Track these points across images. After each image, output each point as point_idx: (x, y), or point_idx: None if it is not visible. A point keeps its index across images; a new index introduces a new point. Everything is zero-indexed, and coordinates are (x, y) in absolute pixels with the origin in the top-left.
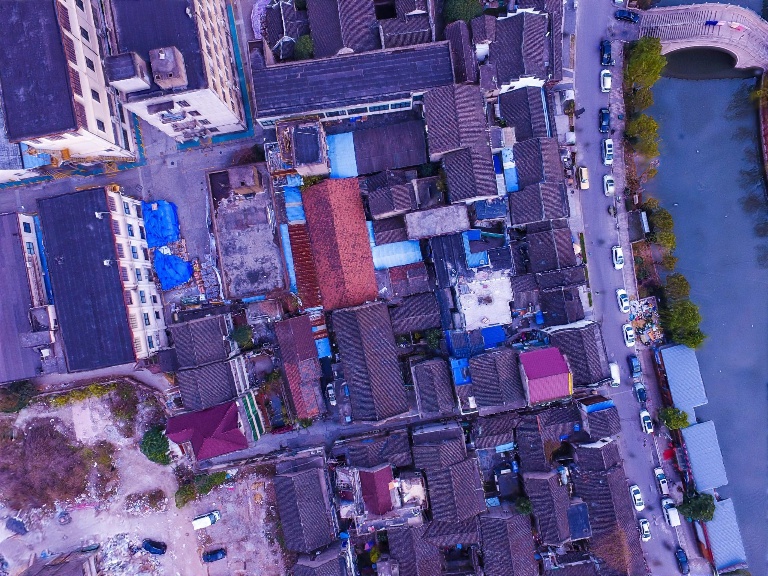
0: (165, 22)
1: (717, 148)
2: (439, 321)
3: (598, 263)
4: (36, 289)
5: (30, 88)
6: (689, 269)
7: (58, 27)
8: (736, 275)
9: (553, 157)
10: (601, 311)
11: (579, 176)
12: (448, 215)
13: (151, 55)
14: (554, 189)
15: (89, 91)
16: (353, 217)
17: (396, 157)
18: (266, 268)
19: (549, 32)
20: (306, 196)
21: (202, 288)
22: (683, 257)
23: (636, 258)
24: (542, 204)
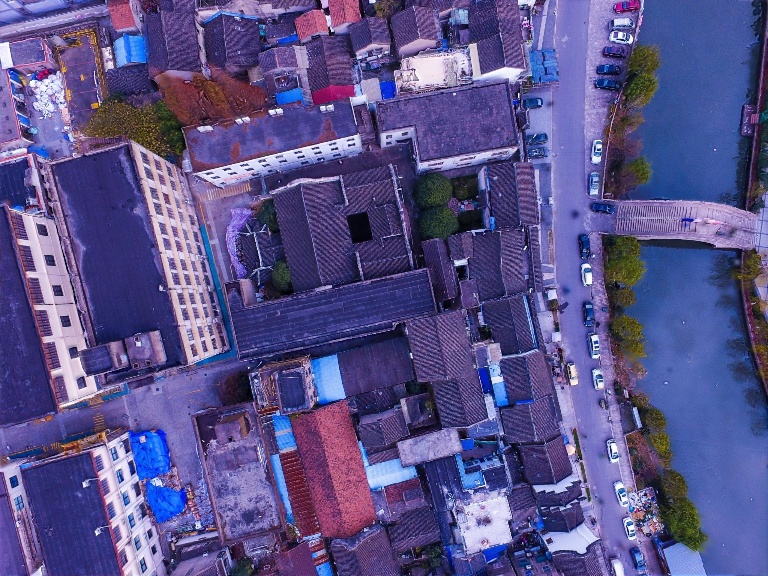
0: (139, 297)
1: (702, 317)
2: (439, 536)
3: (593, 457)
4: (28, 547)
5: (6, 375)
6: (684, 440)
7: (30, 309)
8: (731, 444)
9: (540, 371)
10: (600, 505)
11: (568, 373)
12: (440, 439)
13: (127, 343)
14: (544, 405)
15: (67, 355)
16: (344, 442)
17: (383, 378)
18: (260, 507)
19: (527, 246)
20: (295, 423)
21: (197, 515)
22: (677, 428)
23: (631, 450)
24: (533, 427)
